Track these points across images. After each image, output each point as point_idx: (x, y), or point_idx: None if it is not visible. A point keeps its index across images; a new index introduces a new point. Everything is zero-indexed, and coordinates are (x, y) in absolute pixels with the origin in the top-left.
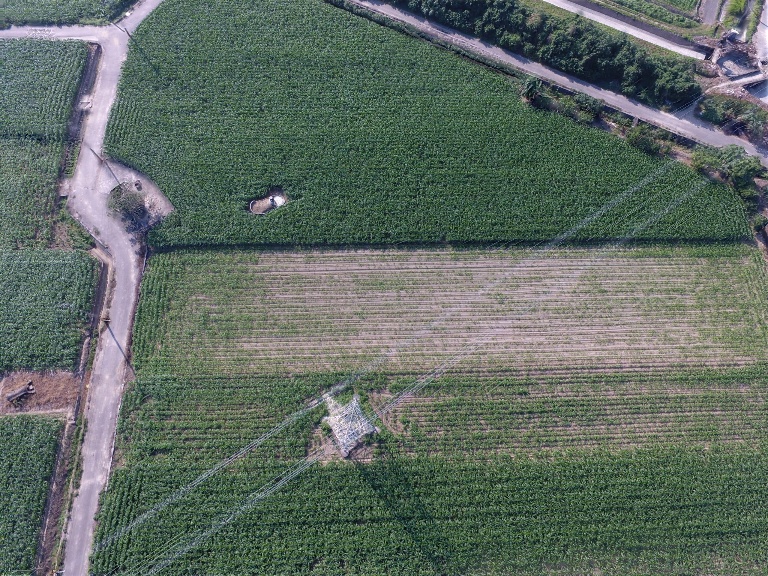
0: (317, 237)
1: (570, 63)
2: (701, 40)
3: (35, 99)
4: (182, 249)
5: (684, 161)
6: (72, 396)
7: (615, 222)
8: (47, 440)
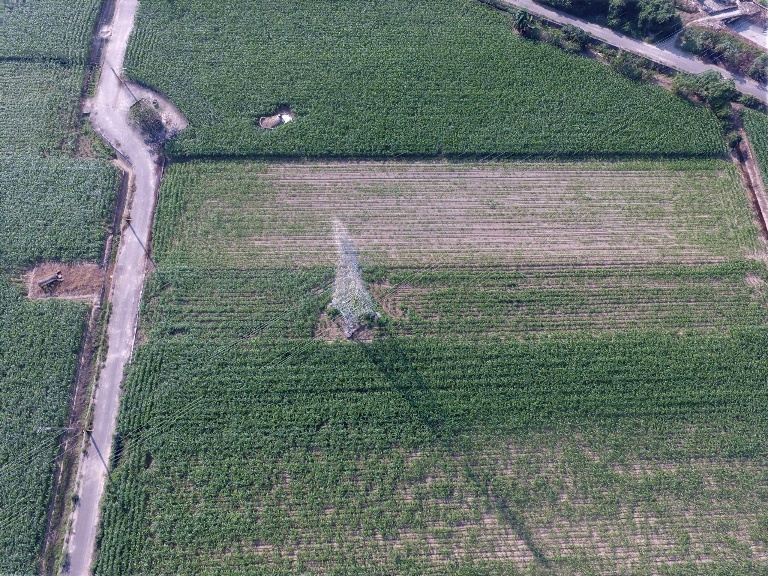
0: (322, 149)
1: None
2: None
3: (58, 27)
4: (197, 159)
5: (665, 86)
6: (97, 284)
7: (599, 138)
8: (76, 319)
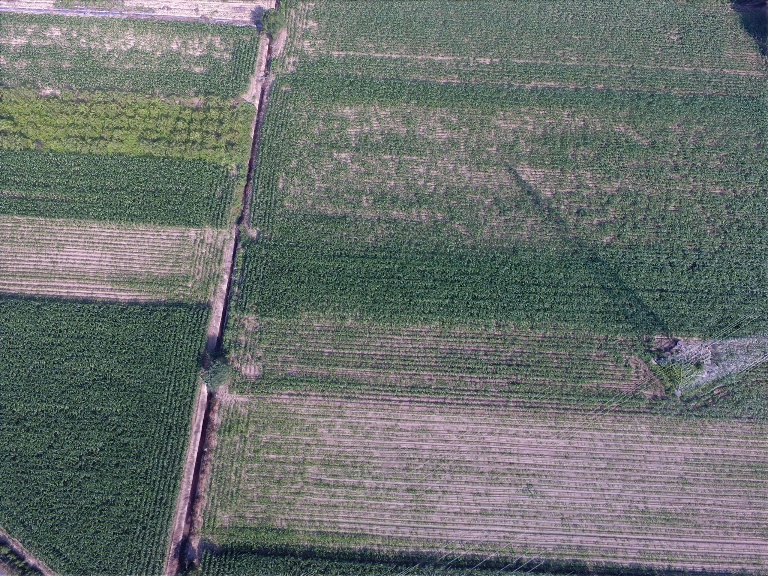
0: None
1: None
2: None
3: None
4: None
5: None
6: None
7: None
8: None
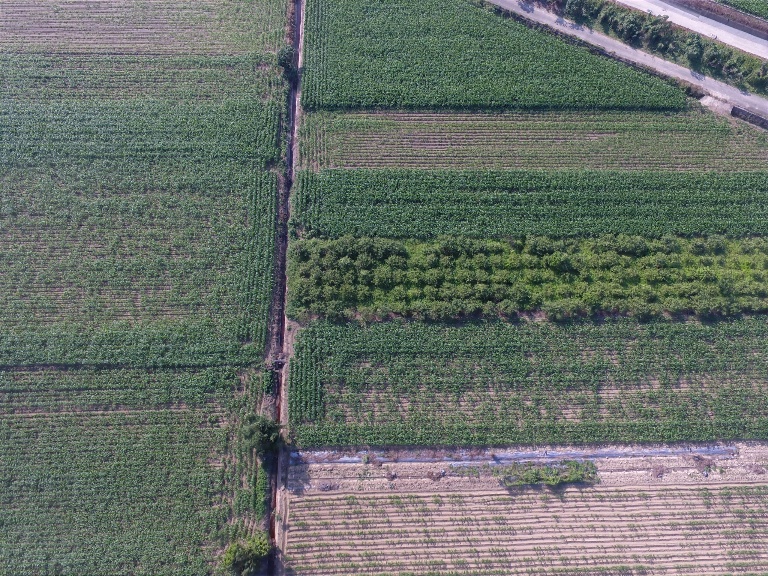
0: None
1: None
2: None
3: None
4: None
5: None
6: None
7: None
8: None
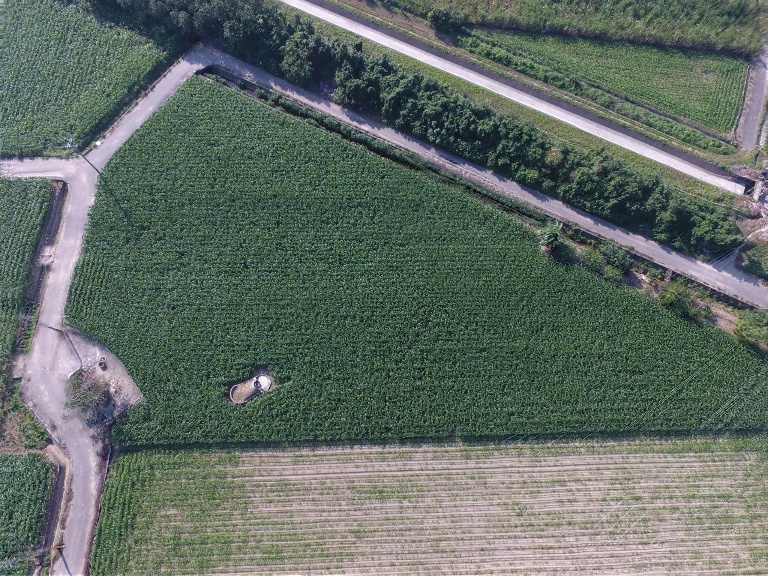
0: (307, 433)
1: (595, 205)
2: (740, 170)
3: None
4: (151, 449)
5: (726, 325)
6: None
7: (650, 409)
8: None
